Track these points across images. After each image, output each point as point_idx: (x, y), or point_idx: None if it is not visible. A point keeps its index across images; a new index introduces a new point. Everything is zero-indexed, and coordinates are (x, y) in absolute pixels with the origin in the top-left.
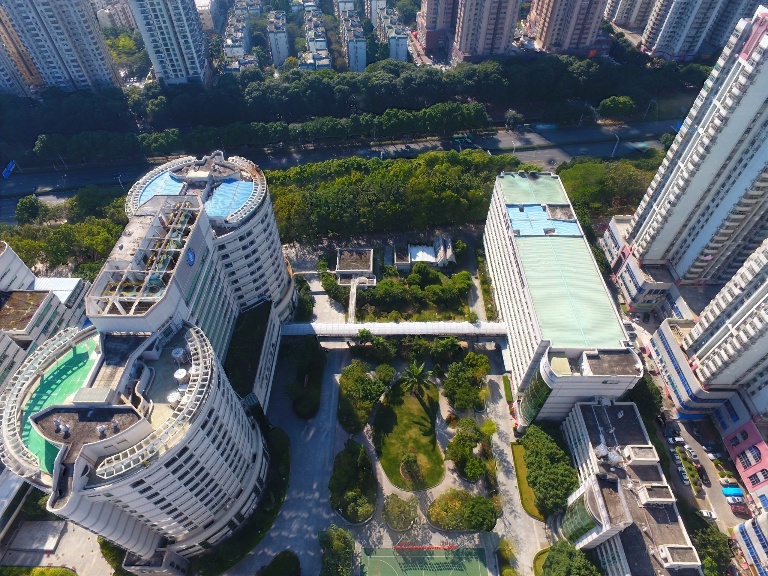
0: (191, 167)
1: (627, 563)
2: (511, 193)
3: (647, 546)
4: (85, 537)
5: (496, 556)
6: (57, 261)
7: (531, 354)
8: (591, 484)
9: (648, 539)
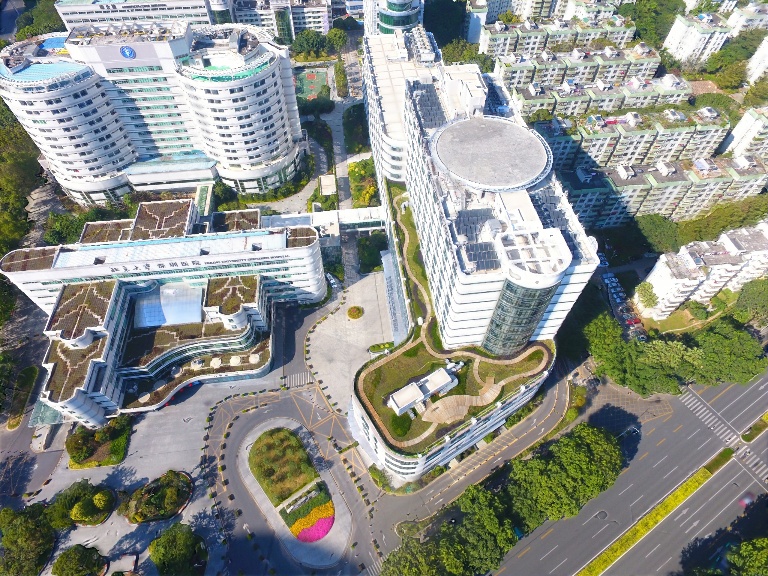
0: (14, 56)
1: (300, 8)
2: (80, 3)
3: (295, 6)
4: (291, 202)
5: (297, 70)
6: (1, 316)
7: (207, 18)
8: (273, 6)
9: (292, 5)
